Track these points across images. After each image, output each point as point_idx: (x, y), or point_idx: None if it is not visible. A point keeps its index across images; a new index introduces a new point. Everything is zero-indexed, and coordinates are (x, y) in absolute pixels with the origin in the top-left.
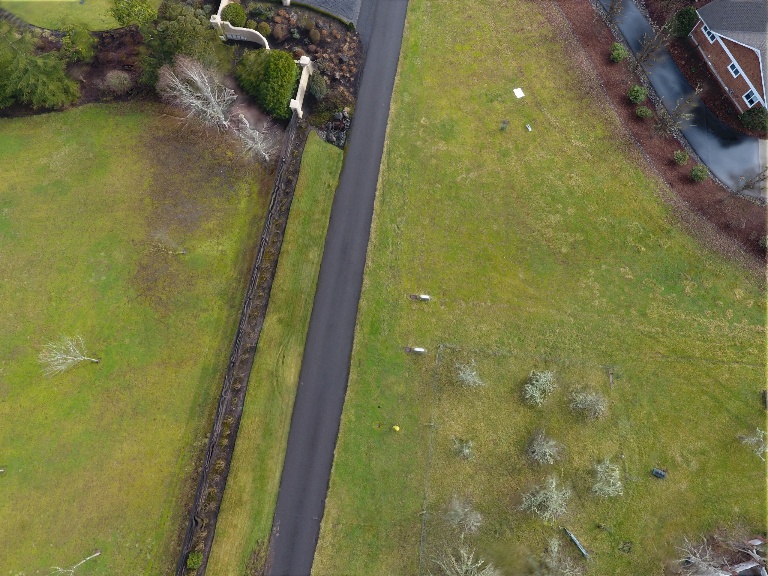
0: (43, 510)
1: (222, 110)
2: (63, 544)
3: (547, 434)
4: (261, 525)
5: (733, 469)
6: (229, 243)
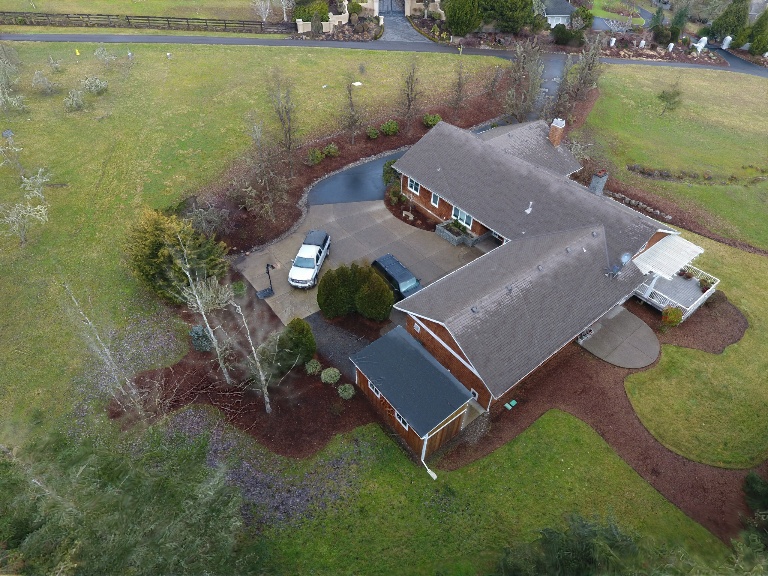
0: (61, 0)
1: (287, 9)
2: (43, 3)
3: (59, 95)
4: None
5: None
6: None
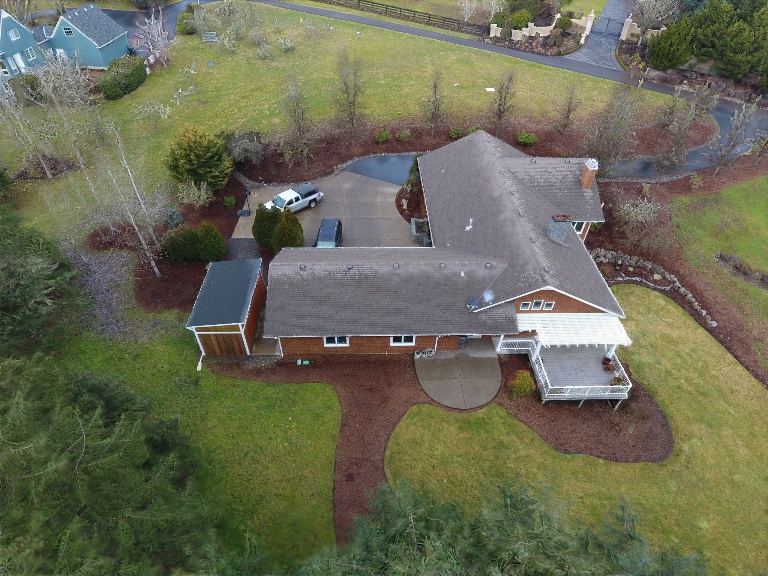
0: None
1: None
2: None
3: None
4: (291, 2)
5: None
6: None
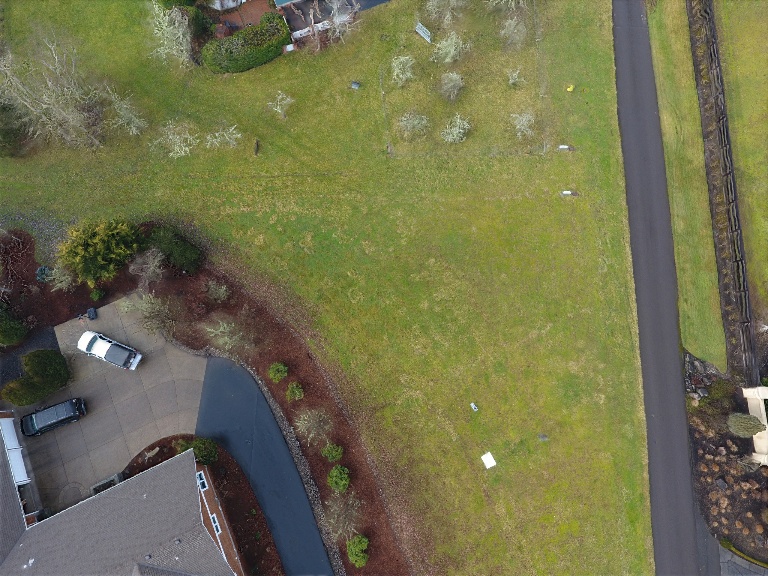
0: None
1: None
2: None
3: (445, 101)
4: (655, 20)
5: (295, 95)
6: (765, 229)
